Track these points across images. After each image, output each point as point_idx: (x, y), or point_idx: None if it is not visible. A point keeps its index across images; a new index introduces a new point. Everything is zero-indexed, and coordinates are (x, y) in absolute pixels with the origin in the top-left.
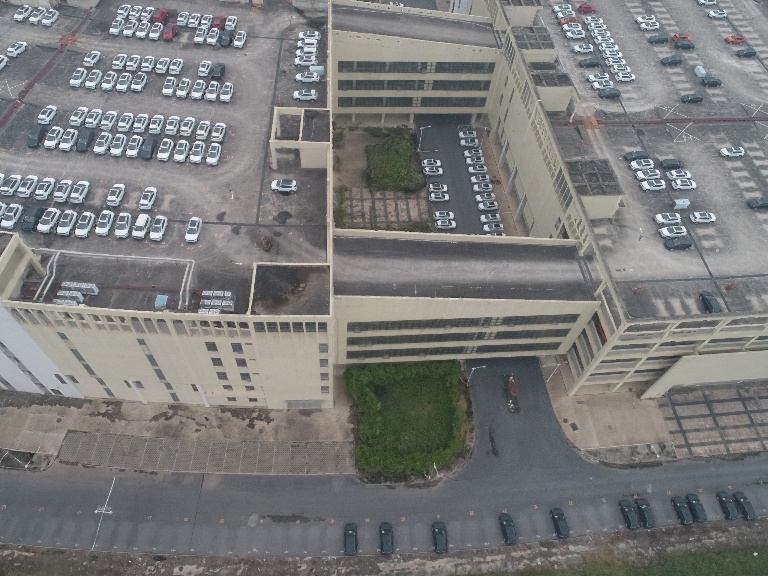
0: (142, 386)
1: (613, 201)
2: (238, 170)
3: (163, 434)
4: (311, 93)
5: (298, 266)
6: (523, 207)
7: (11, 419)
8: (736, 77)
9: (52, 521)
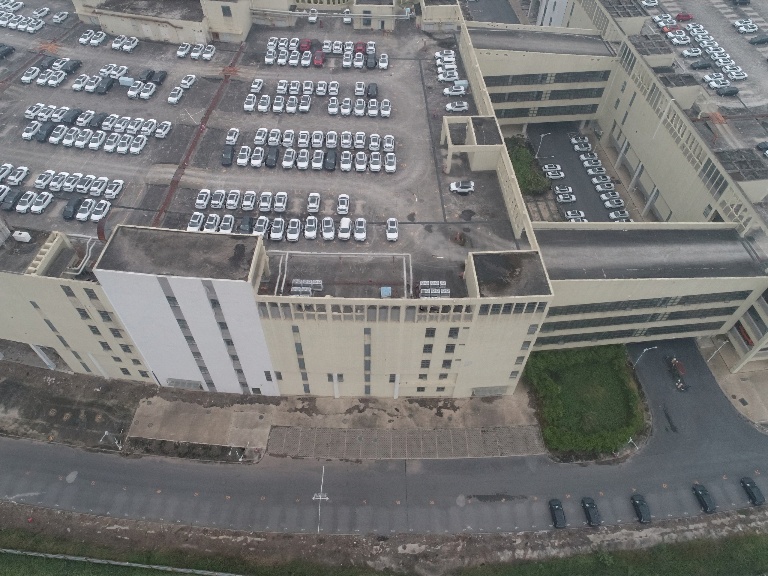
0: (342, 379)
1: (766, 185)
2: (415, 176)
3: (359, 425)
4: (464, 104)
5: (509, 253)
6: (654, 202)
7: (217, 418)
8: None
9: (275, 509)
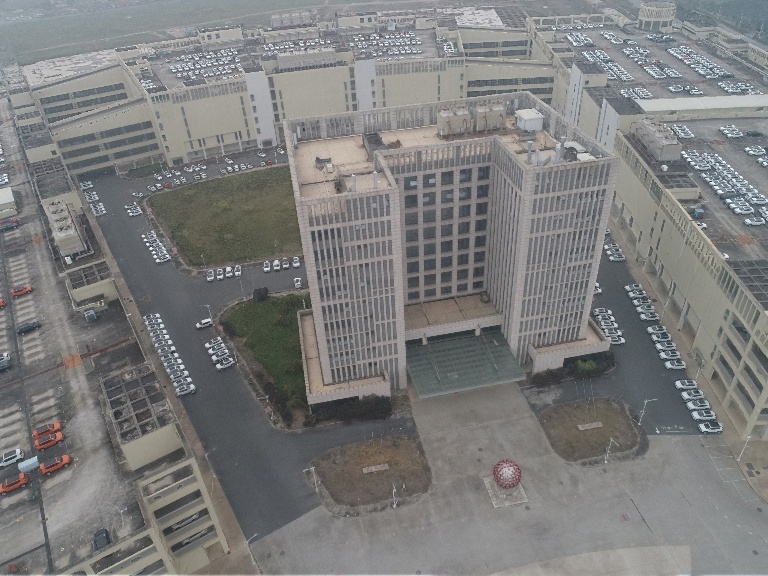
0: None
1: None
2: None
3: None
4: None
5: None
6: None
7: None
8: None
9: None
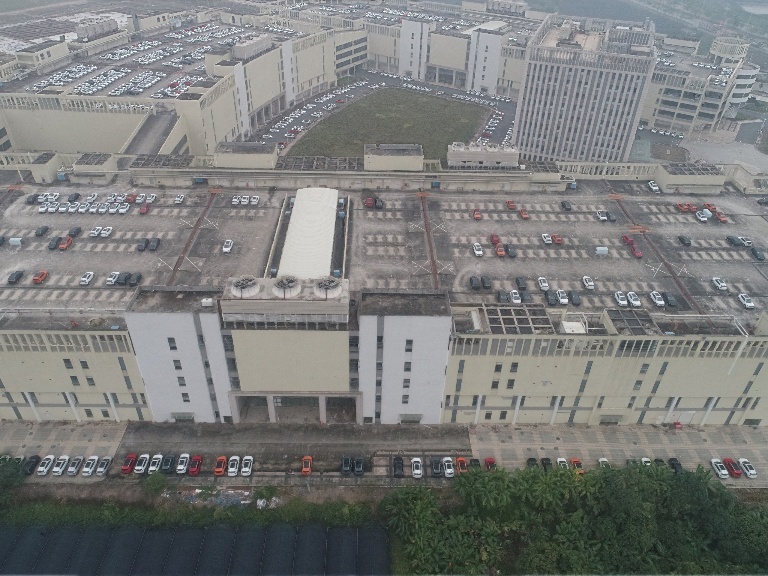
0: None
1: None
2: None
3: None
4: None
5: None
6: None
7: None
8: None
9: None
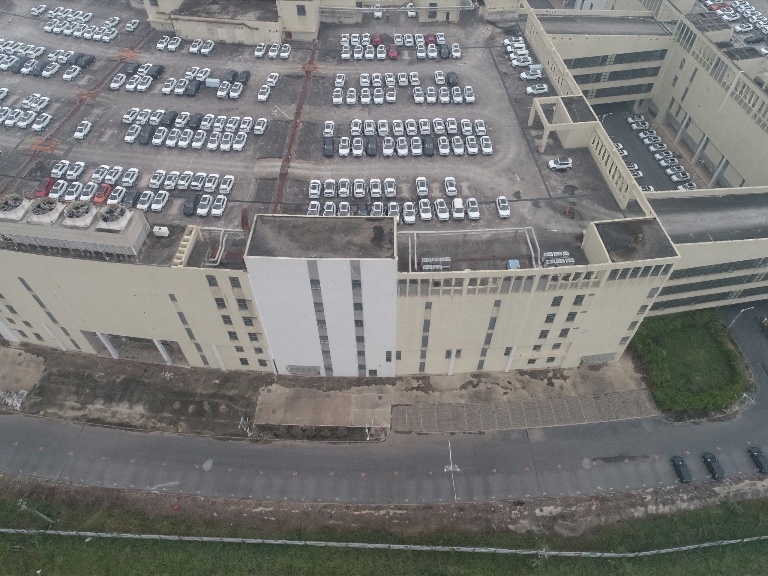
0: (459, 355)
1: None
2: (511, 156)
3: (476, 399)
4: (544, 87)
5: (628, 221)
6: (722, 172)
7: (338, 401)
8: None
9: (410, 482)
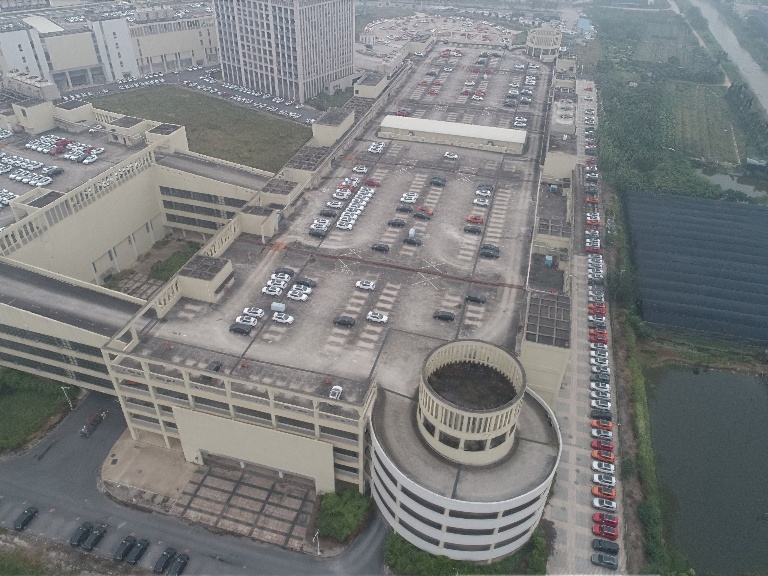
0: None
1: (204, 285)
2: None
3: None
4: None
5: None
6: None
7: None
8: (444, 243)
9: None
